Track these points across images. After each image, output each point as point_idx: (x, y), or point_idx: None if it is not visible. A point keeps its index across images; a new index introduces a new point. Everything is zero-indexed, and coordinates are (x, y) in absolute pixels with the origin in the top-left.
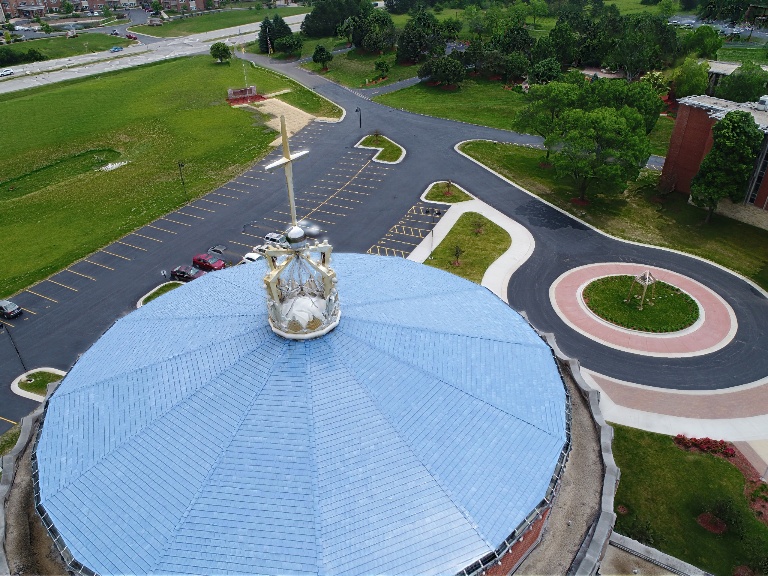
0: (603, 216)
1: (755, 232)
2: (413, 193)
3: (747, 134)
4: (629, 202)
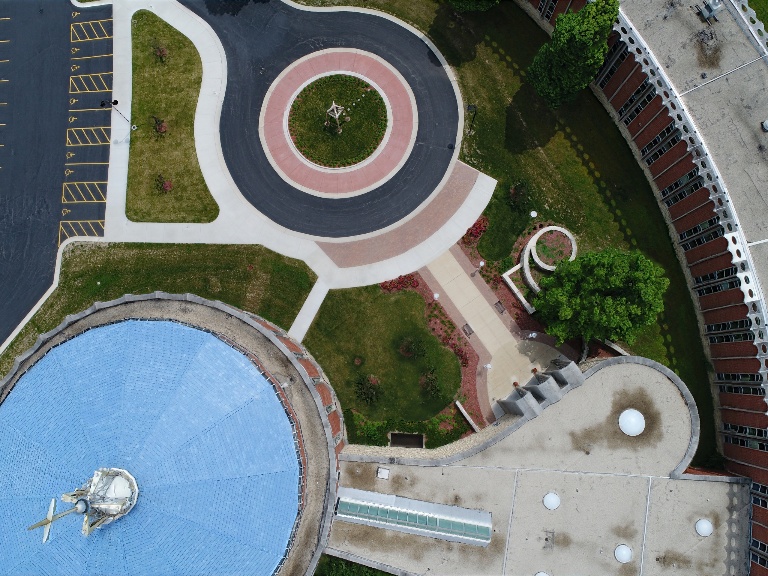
0: None
1: None
2: None
3: None
4: None
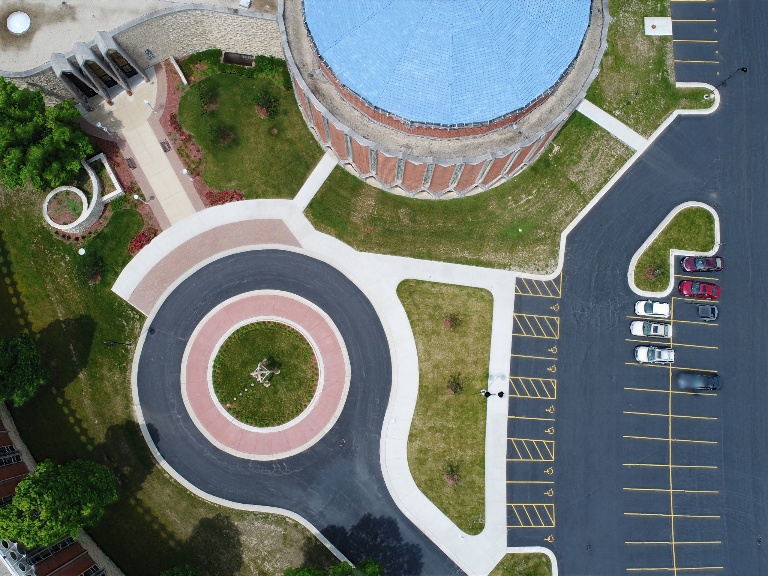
0: None
1: (135, 564)
2: (572, 571)
3: None
4: None
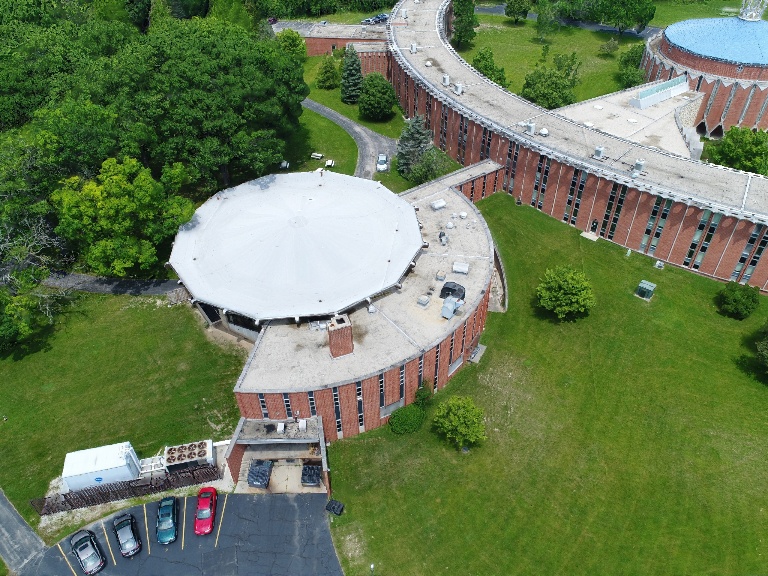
0: None
1: None
2: None
3: None
4: None
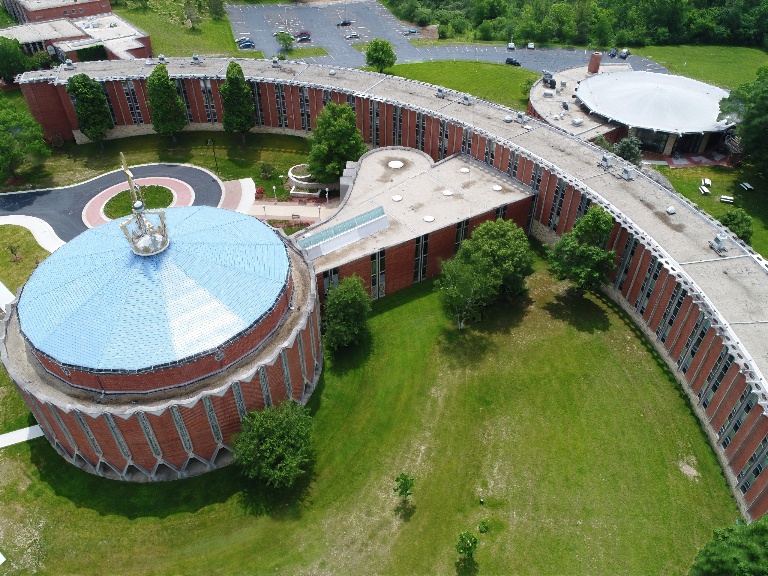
0: (44, 180)
1: (132, 139)
2: None
3: (94, 87)
4: (44, 163)
